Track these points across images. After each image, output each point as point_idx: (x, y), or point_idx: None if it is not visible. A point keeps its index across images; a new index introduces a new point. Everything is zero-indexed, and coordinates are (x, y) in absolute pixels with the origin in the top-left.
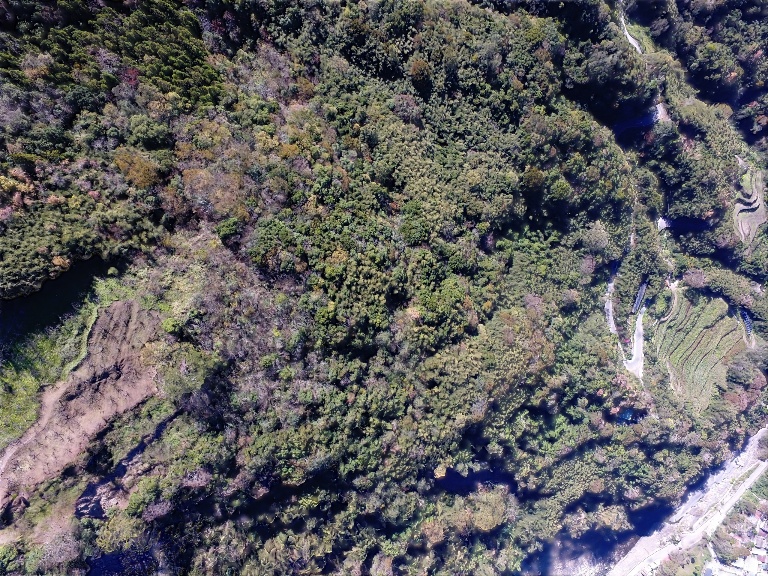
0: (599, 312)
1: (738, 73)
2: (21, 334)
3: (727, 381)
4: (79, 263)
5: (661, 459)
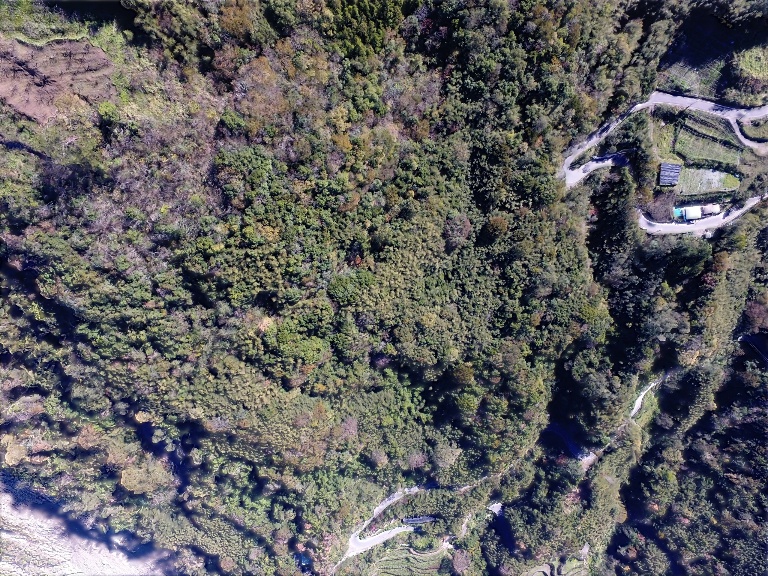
0: (387, 490)
1: (659, 510)
2: None
3: None
4: (119, 0)
5: None
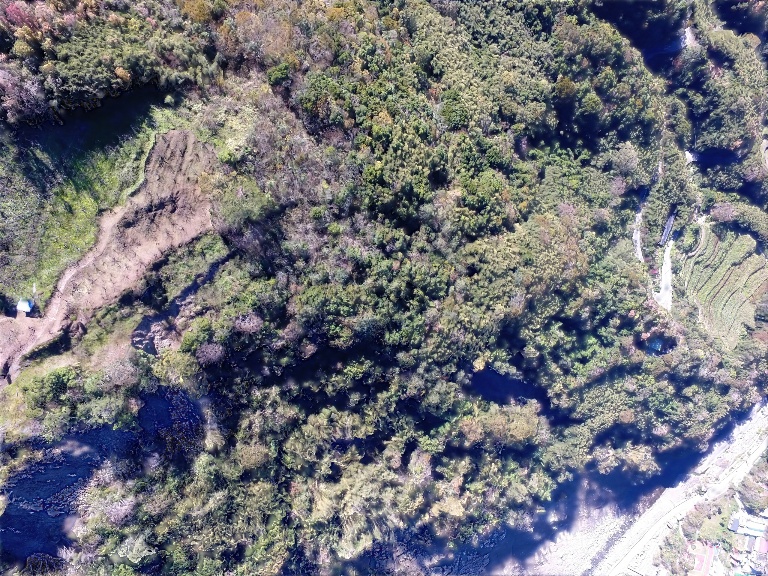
0: None
1: (766, 2)
2: (82, 150)
3: (755, 320)
4: (137, 90)
5: (690, 394)
